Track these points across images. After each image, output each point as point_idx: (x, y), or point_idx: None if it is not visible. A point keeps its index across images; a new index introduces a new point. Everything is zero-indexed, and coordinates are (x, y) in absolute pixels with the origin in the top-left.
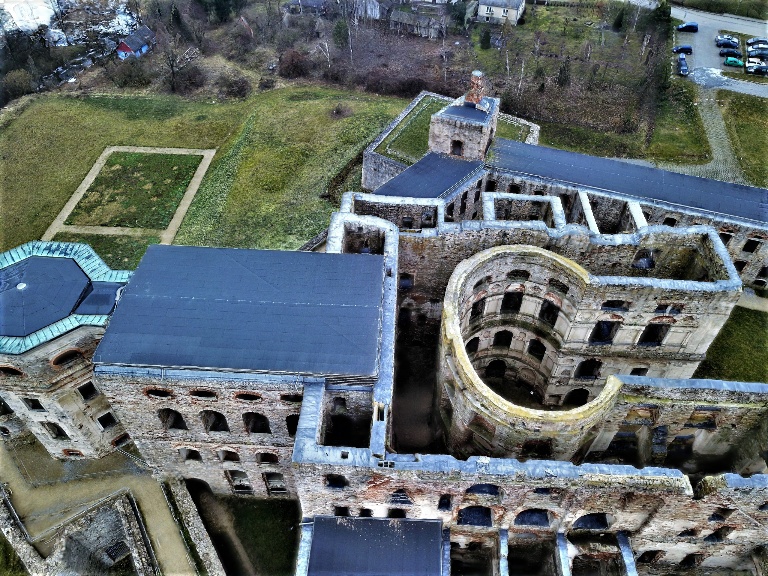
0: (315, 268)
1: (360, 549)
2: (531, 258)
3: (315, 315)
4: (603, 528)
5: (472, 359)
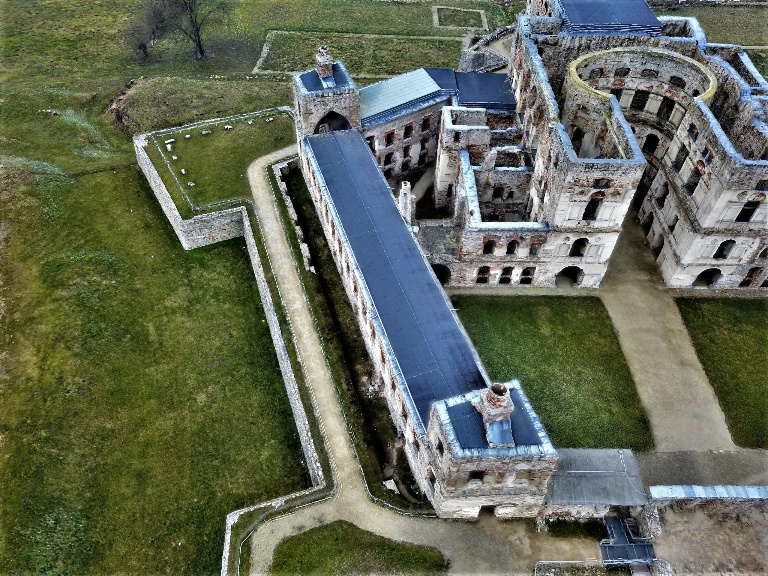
0: (636, 8)
1: (496, 84)
2: (706, 84)
3: (601, 8)
4: (534, 160)
5: (649, 159)
